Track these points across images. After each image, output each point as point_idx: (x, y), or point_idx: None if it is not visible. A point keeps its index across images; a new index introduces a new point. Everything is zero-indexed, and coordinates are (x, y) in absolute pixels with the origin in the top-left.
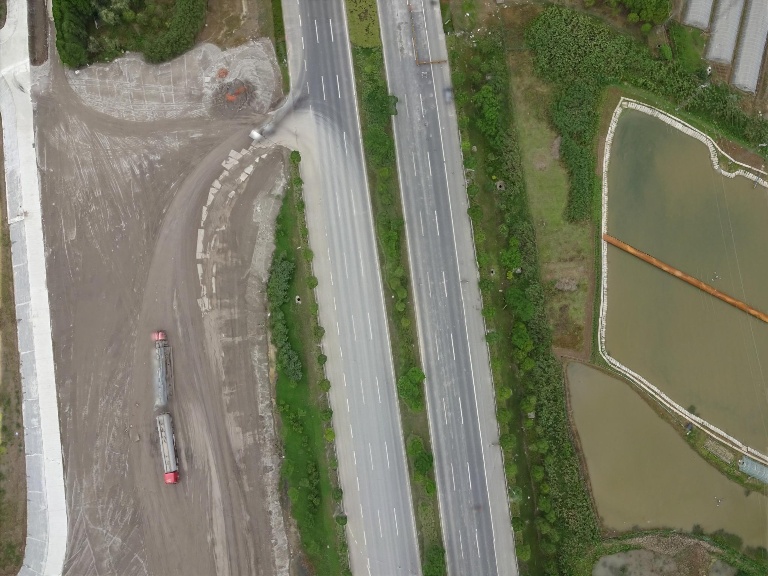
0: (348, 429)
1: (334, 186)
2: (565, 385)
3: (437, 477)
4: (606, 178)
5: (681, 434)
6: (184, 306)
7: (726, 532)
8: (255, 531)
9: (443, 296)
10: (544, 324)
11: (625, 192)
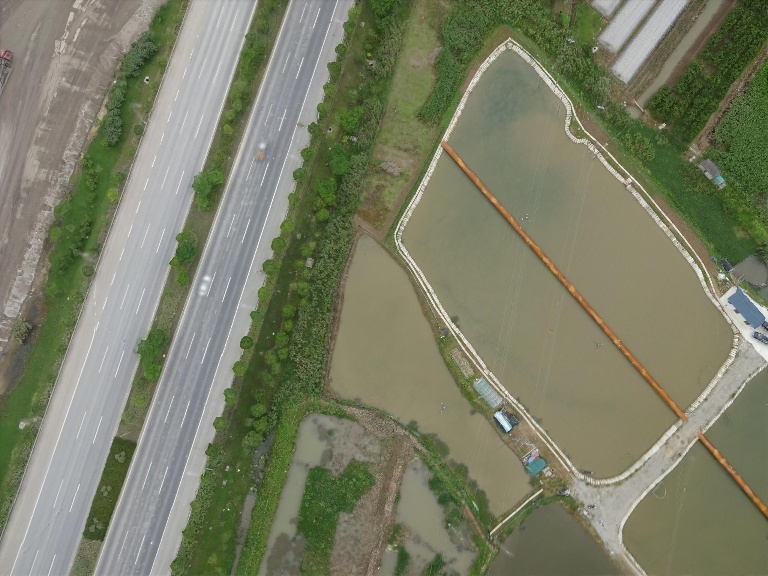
0: (136, 204)
1: (224, 0)
2: (351, 251)
3: (197, 278)
4: (467, 97)
5: (435, 335)
6: (41, 41)
7: (438, 438)
8: (7, 255)
9: (276, 129)
10: (355, 190)
11: (478, 115)
